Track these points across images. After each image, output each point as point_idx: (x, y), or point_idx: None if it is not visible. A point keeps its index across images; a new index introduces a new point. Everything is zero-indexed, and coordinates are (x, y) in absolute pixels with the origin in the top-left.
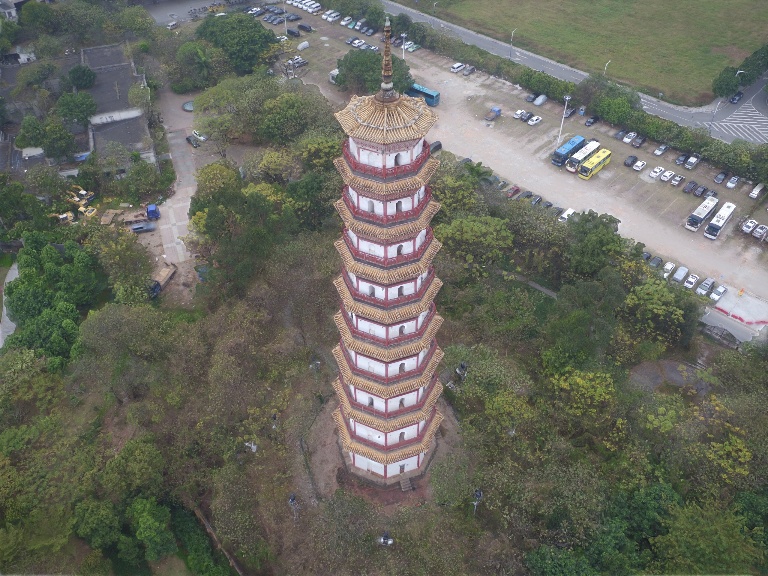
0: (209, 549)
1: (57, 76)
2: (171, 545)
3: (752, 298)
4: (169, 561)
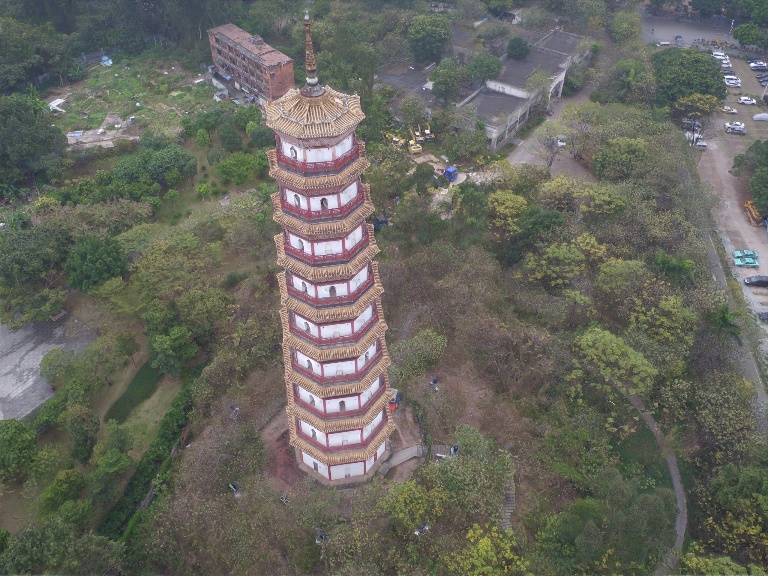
0: None
1: None
2: (174, 371)
3: None
4: (175, 384)
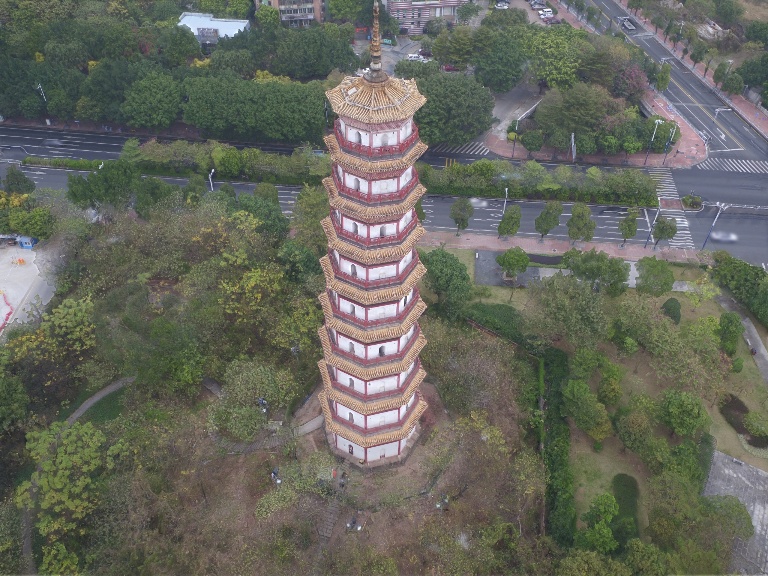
0: None
1: None
2: None
3: None
4: None
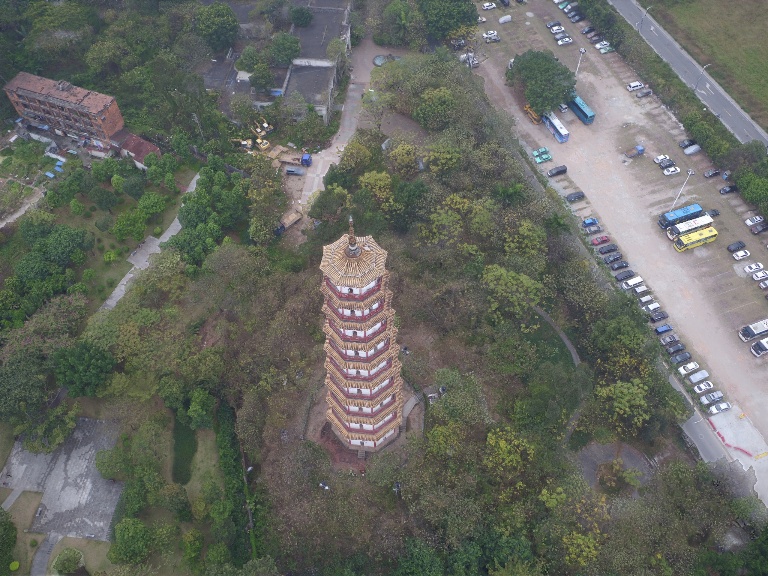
0: (233, 435)
1: None
2: (209, 424)
3: (750, 425)
4: (208, 431)
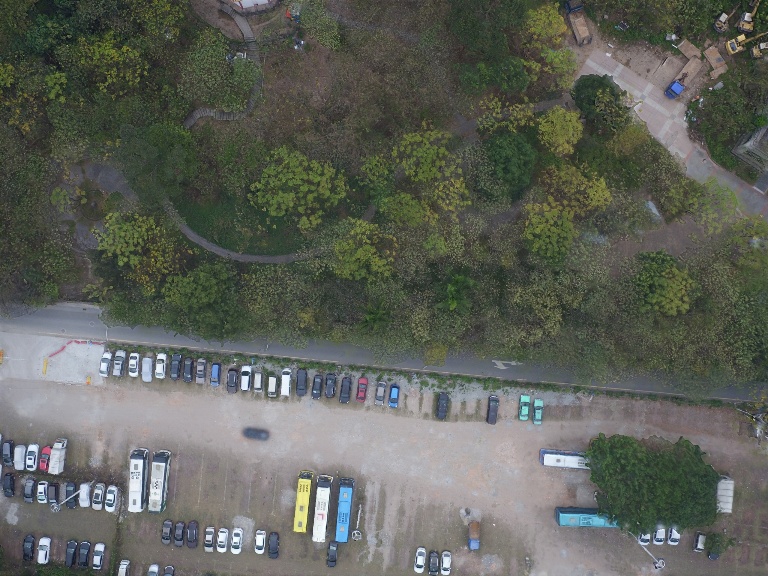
0: None
1: None
2: None
3: None
4: None
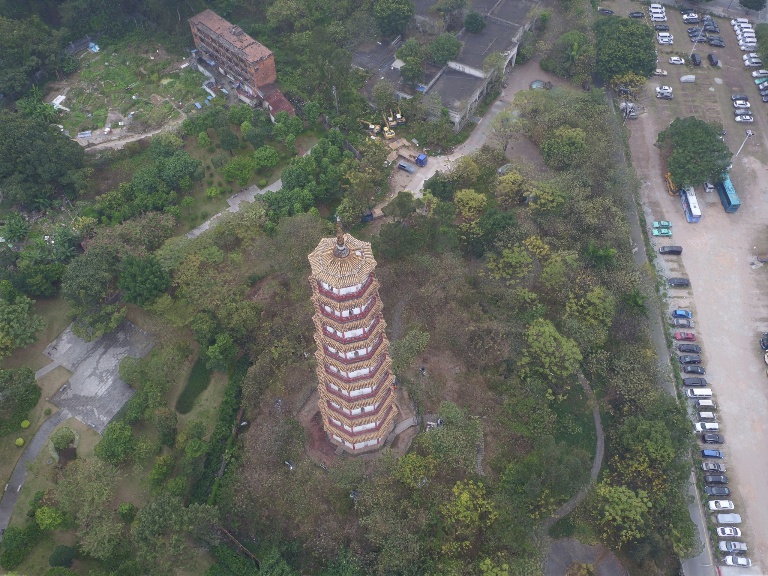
0: None
1: (470, 8)
2: (223, 369)
3: None
4: (223, 375)
